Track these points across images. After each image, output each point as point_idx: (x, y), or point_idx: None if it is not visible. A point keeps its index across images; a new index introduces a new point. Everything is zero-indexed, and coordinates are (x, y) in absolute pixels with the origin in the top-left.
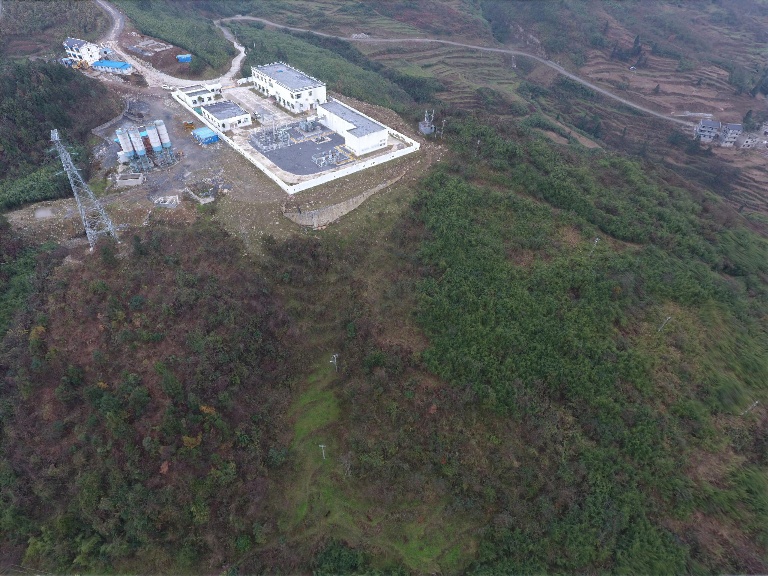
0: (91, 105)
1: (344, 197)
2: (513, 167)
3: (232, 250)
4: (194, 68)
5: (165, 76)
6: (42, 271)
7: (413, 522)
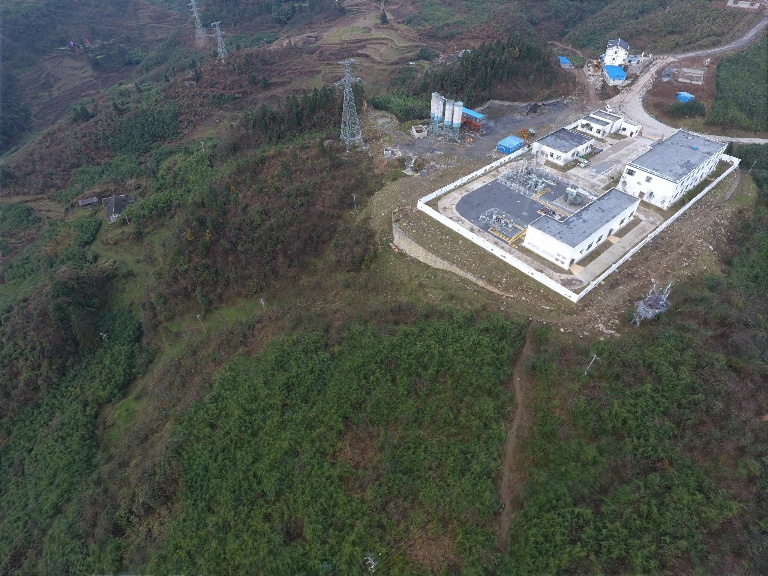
0: (517, 85)
1: (432, 247)
2: (594, 442)
3: (349, 202)
4: (672, 109)
5: (637, 102)
6: (318, 137)
7: (146, 402)
